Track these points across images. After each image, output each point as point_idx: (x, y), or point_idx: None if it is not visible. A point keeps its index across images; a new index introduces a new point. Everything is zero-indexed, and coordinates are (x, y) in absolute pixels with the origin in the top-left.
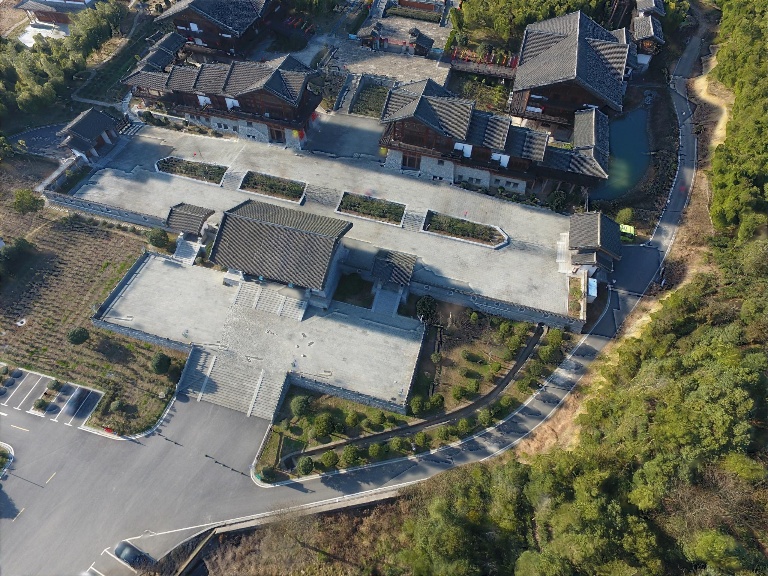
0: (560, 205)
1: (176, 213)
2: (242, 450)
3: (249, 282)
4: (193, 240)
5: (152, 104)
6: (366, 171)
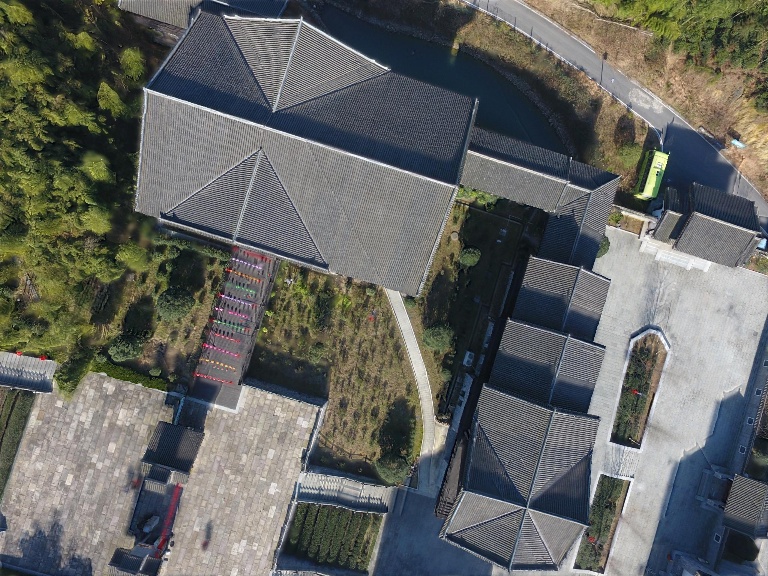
0: None
1: None
2: None
3: None
4: None
5: None
6: None
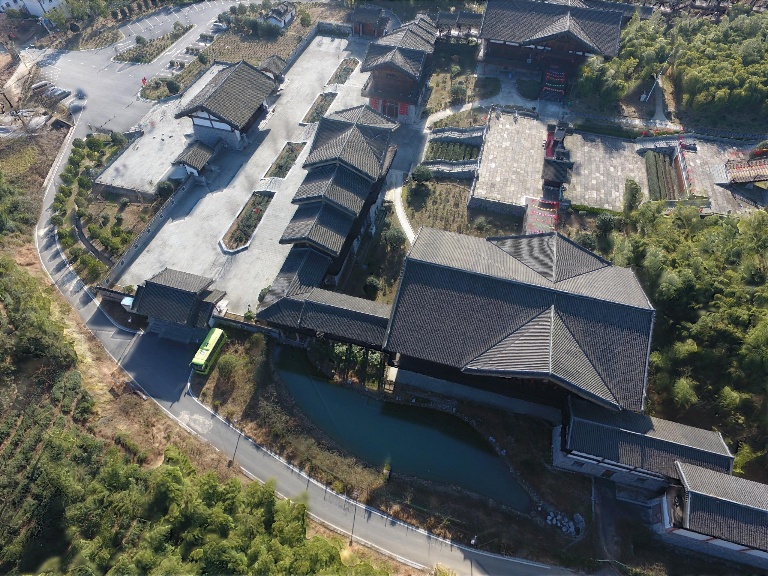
0: None
1: None
2: (111, 128)
3: None
4: None
5: None
6: None
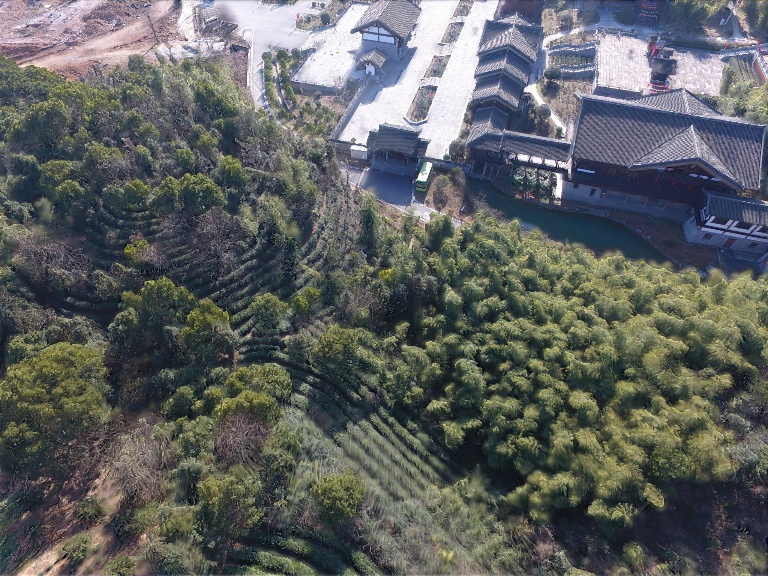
0: None
1: None
2: None
3: None
4: None
5: None
6: (476, 62)
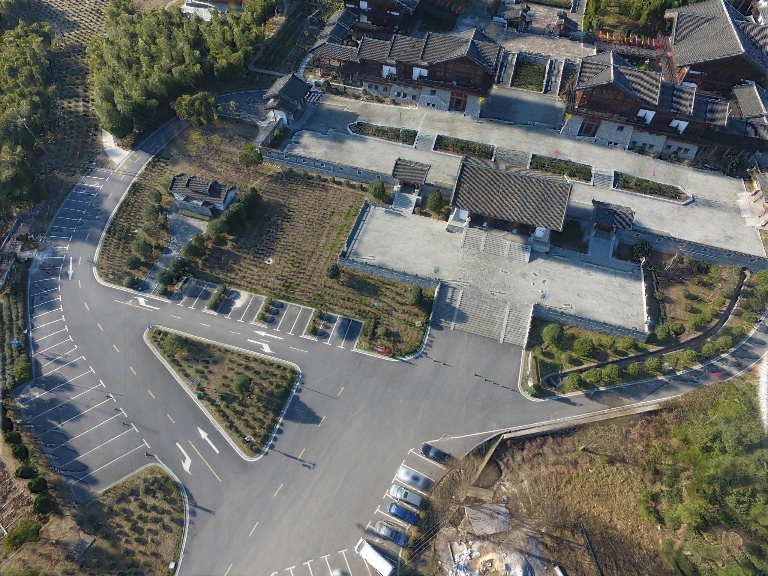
0: (734, 168)
1: (401, 166)
2: (505, 370)
3: (473, 228)
4: (408, 192)
5: (327, 75)
6: (545, 137)
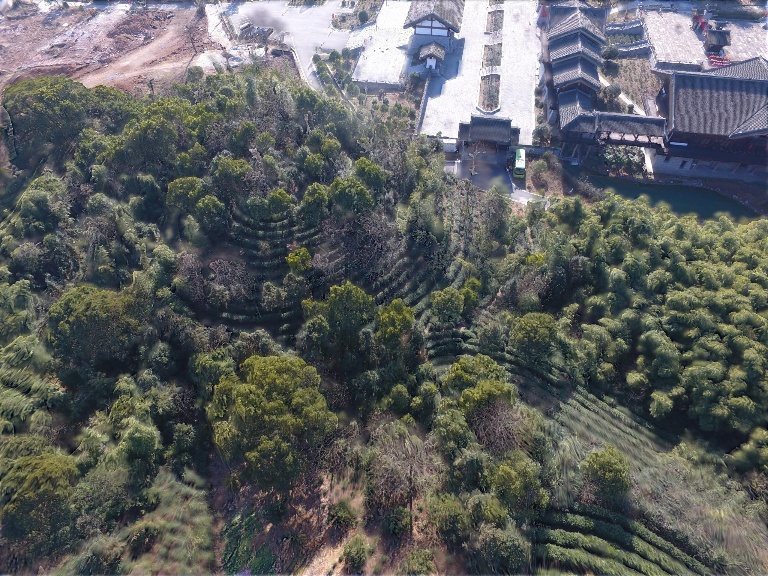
0: (535, 131)
1: None
2: None
3: None
4: None
5: None
6: (529, 48)
